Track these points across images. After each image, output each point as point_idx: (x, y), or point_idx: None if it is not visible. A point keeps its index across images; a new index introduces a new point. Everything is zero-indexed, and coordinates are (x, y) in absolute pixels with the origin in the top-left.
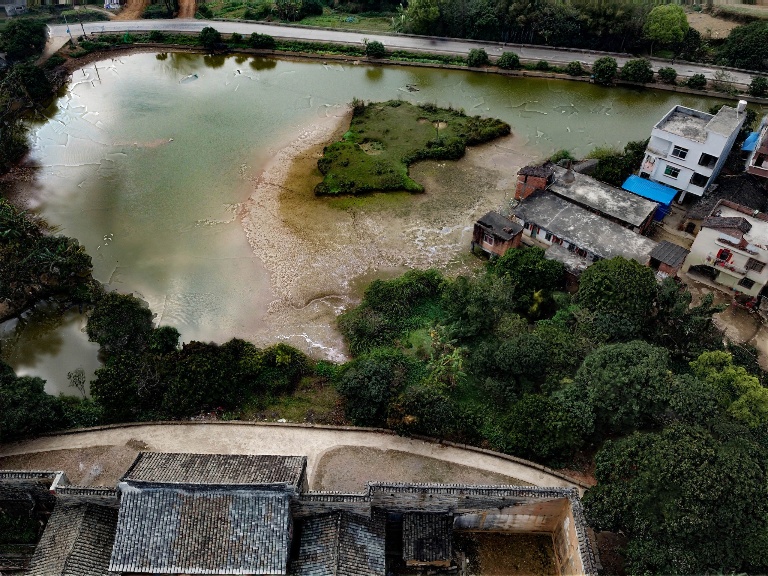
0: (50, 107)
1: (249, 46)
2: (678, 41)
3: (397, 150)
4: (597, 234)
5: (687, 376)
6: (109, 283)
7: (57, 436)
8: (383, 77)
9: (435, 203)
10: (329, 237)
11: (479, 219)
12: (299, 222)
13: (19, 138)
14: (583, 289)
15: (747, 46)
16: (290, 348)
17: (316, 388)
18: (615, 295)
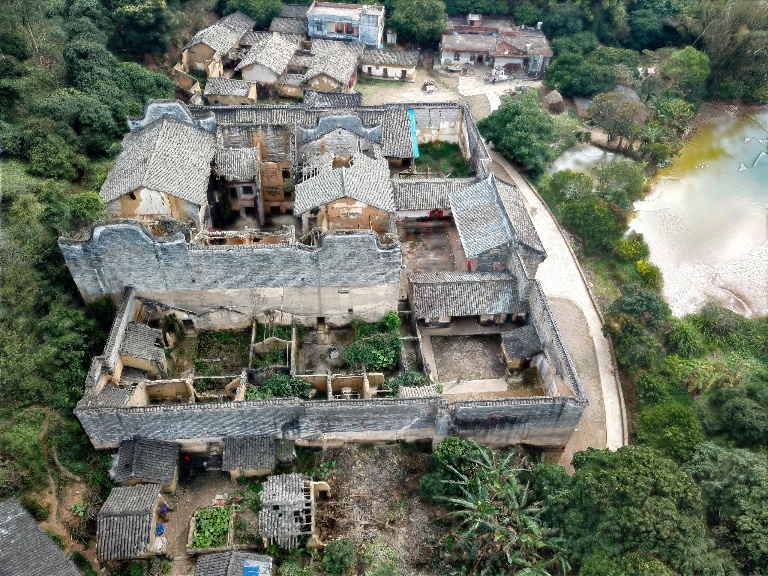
0: None
1: None
2: None
3: None
4: None
5: None
6: None
7: (524, 180)
8: None
9: None
10: None
11: None
12: None
13: (762, 91)
14: None
15: None
16: None
17: None
18: None
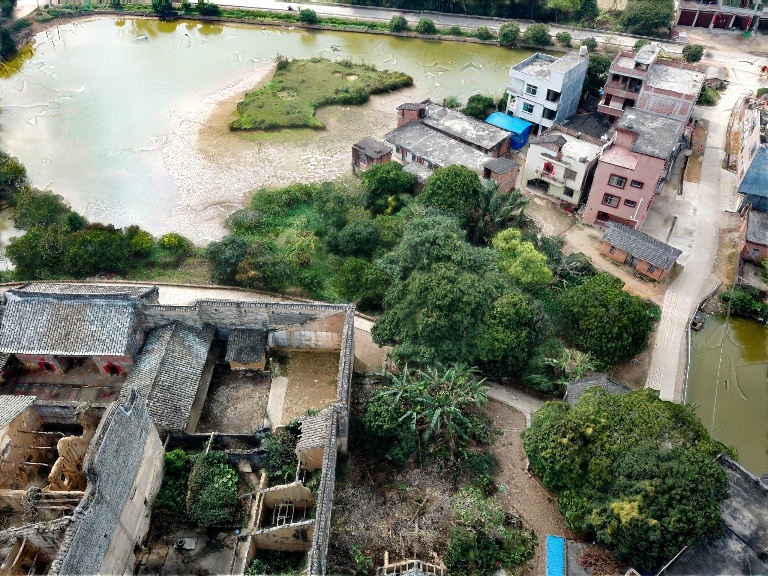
0: (14, 63)
1: (197, 13)
2: (576, 9)
3: (308, 96)
4: (450, 154)
5: (485, 249)
6: None
7: None
8: (316, 42)
9: (332, 137)
10: (235, 161)
11: (356, 143)
12: (212, 150)
13: None
14: (424, 191)
15: (637, 14)
16: None
17: (197, 266)
18: (444, 193)
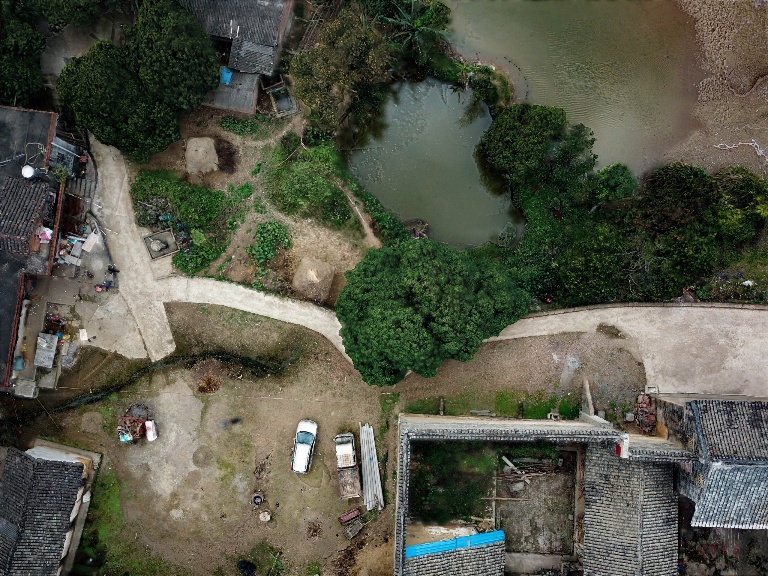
0: None
1: None
2: None
3: None
4: None
5: None
6: (462, 41)
7: None
8: None
9: None
10: None
11: None
12: None
13: None
14: None
15: None
16: (759, 183)
17: None
18: None
